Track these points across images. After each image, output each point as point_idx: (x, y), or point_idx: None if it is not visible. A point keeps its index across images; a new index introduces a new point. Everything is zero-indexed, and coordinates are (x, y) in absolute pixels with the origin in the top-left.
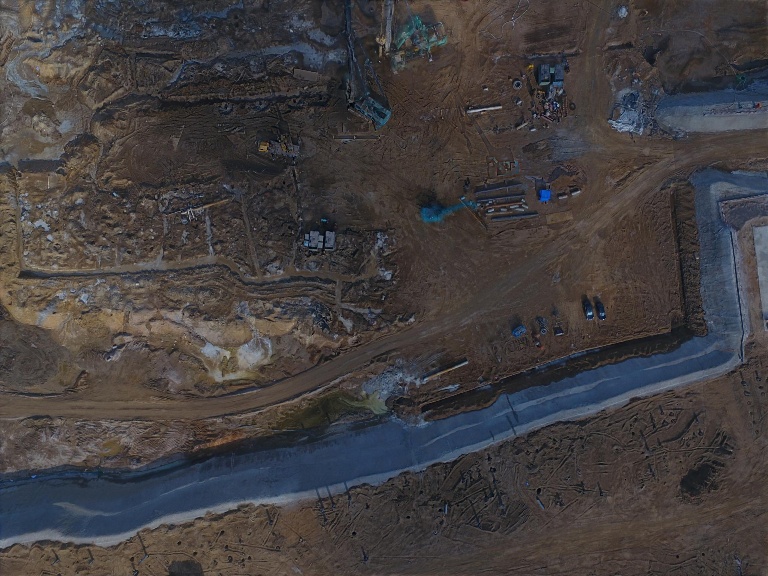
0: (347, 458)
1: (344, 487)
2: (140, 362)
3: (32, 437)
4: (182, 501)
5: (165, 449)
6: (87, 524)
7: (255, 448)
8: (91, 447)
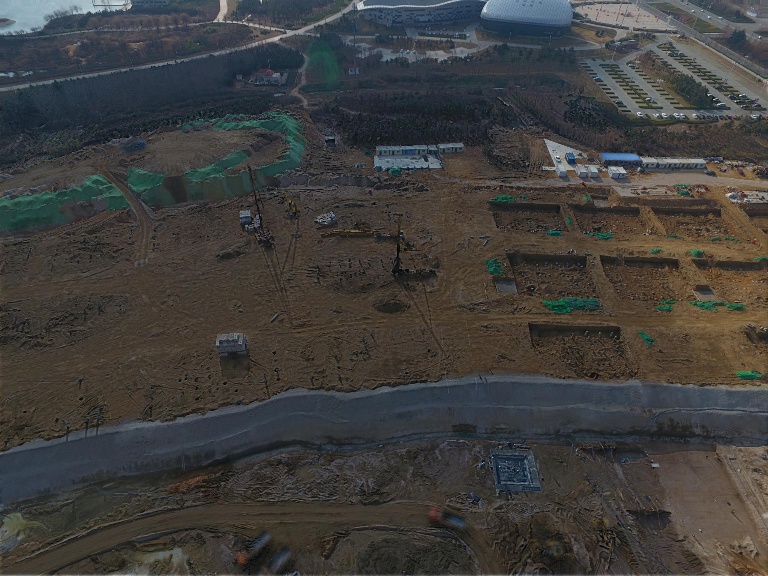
0: (62, 465)
1: (69, 437)
2: (261, 571)
3: (383, 483)
4: (229, 424)
5: (251, 473)
6: (317, 405)
7: (161, 475)
8: (326, 474)
